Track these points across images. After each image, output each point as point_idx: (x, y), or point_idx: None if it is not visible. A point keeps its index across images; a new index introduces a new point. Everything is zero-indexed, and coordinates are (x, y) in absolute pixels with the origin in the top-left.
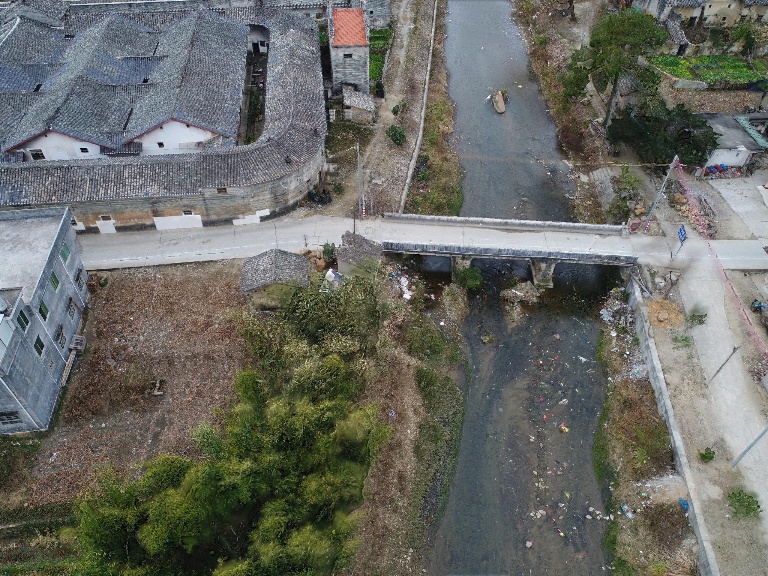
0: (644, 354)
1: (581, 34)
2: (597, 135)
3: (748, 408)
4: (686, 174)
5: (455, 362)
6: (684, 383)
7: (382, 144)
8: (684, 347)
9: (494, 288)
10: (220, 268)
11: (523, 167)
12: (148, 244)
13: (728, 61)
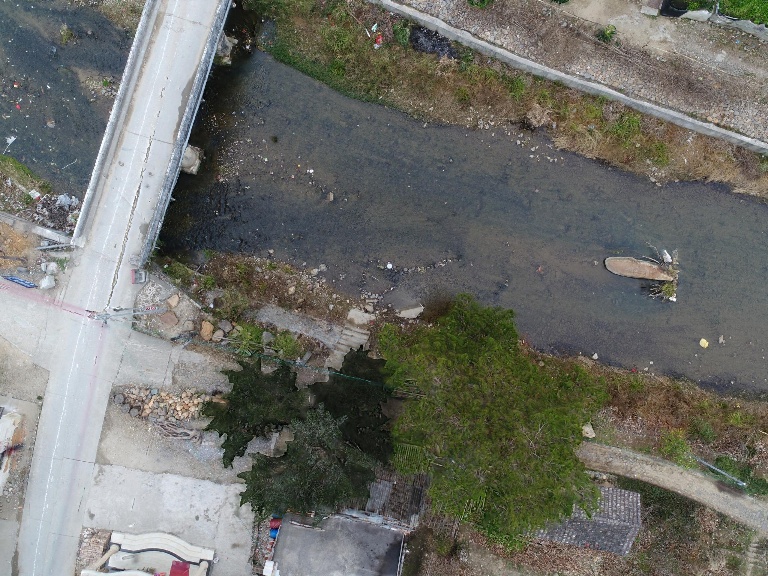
0: None
1: None
2: None
3: None
4: None
5: None
6: None
7: None
8: None
9: None
10: None
11: (419, 231)
12: None
13: None
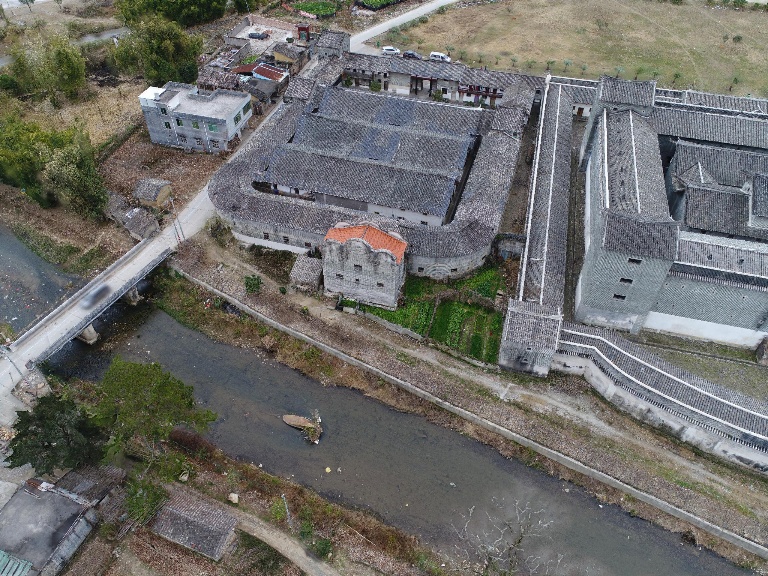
0: None
1: None
2: None
3: None
4: (44, 478)
5: None
6: None
7: None
8: None
9: None
10: None
11: None
12: None
13: None
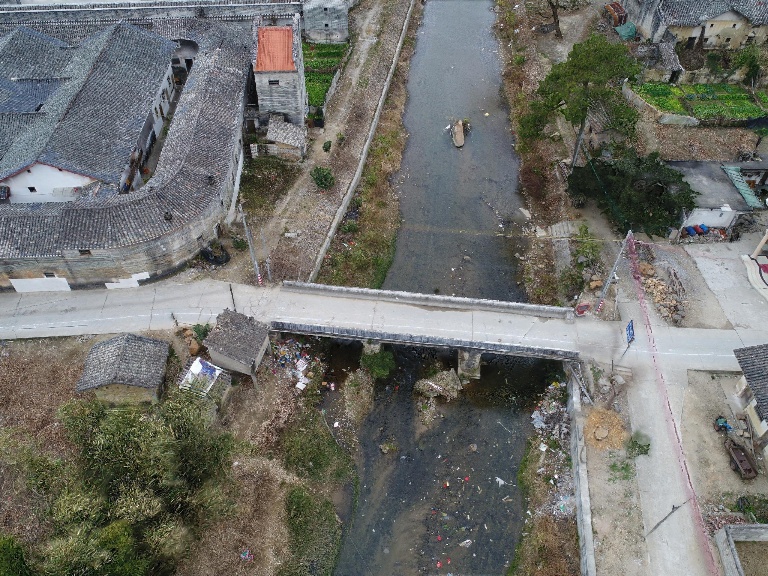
0: (574, 482)
1: (565, 53)
2: (562, 180)
3: (693, 575)
4: None
5: (341, 480)
6: (615, 533)
7: (308, 186)
8: (622, 479)
9: (409, 377)
10: (78, 346)
11: (472, 216)
12: (1, 311)
13: (727, 91)
